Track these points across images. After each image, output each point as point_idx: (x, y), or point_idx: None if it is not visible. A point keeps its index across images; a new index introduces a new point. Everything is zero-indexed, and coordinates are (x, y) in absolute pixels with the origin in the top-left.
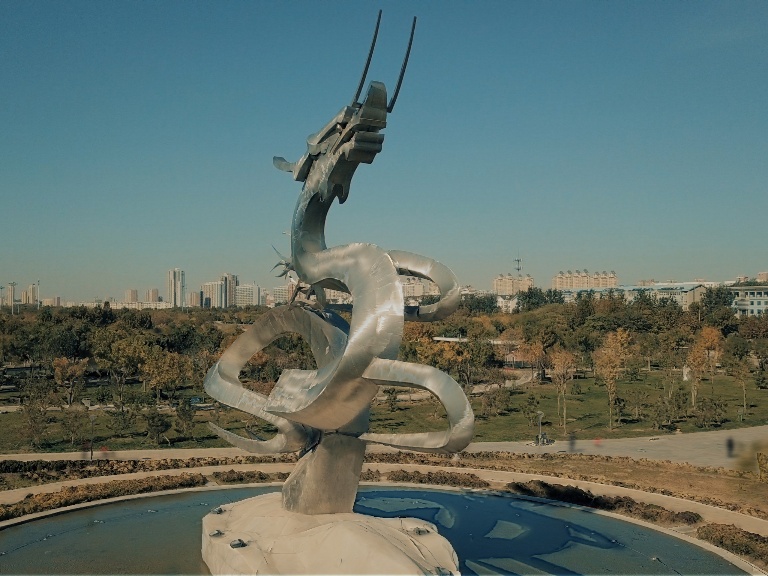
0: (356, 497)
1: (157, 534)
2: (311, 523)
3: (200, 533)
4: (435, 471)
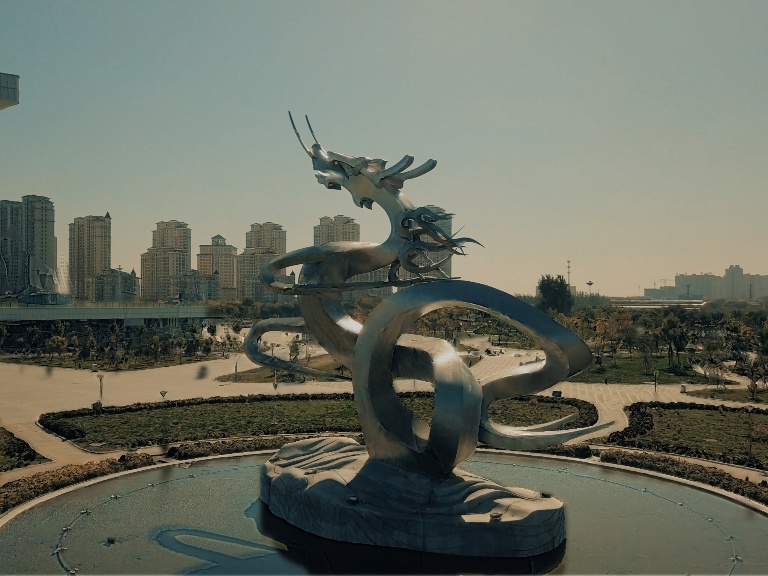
0: None
1: (637, 537)
2: None
3: None
4: None
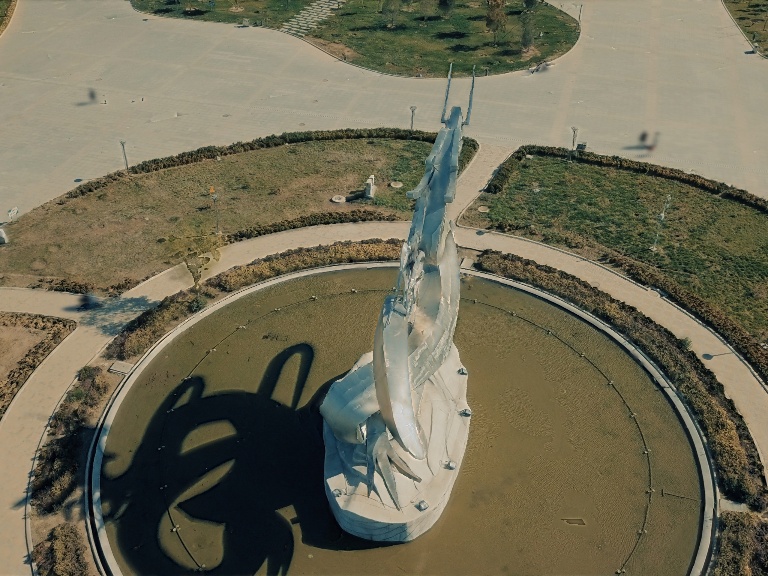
0: None
1: None
2: (426, 388)
3: (411, 569)
4: None
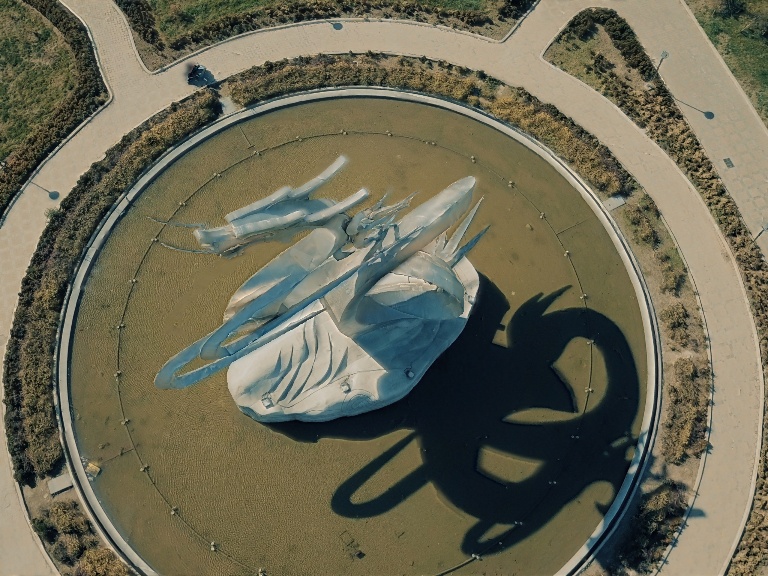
0: (599, 334)
1: None
2: (328, 315)
3: None
4: (735, 407)
